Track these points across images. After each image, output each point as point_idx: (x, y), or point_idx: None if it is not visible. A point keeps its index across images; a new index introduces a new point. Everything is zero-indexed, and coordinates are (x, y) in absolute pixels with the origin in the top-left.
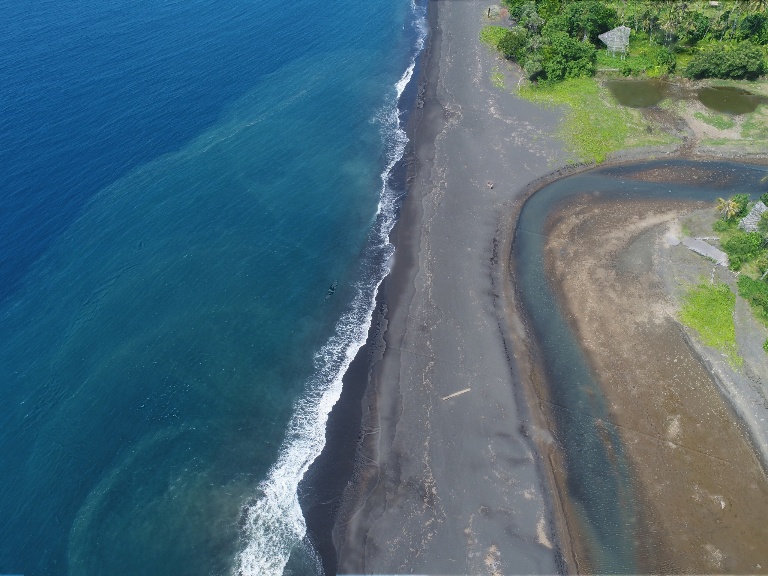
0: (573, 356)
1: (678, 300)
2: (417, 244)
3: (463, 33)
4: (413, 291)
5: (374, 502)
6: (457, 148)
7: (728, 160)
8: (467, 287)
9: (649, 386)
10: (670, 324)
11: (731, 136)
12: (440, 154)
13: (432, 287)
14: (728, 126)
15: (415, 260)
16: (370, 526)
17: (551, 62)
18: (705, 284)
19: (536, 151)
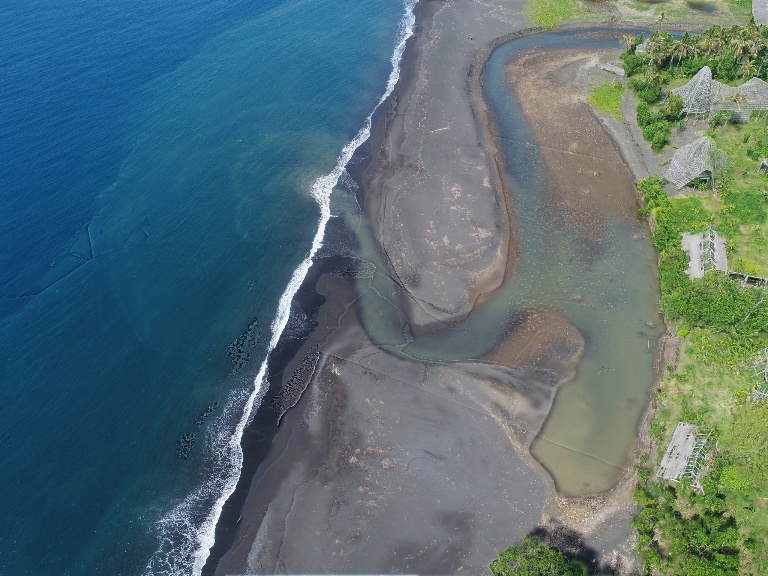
0: (516, 118)
1: (588, 92)
2: (418, 67)
3: None
4: (414, 88)
5: (387, 173)
6: (449, 19)
7: (641, 28)
8: (450, 85)
9: (562, 130)
10: (581, 104)
11: (646, 15)
12: (436, 22)
13: (427, 86)
14: (646, 9)
15: (416, 75)
16: (385, 181)
17: None
18: (607, 84)
19: (505, 21)
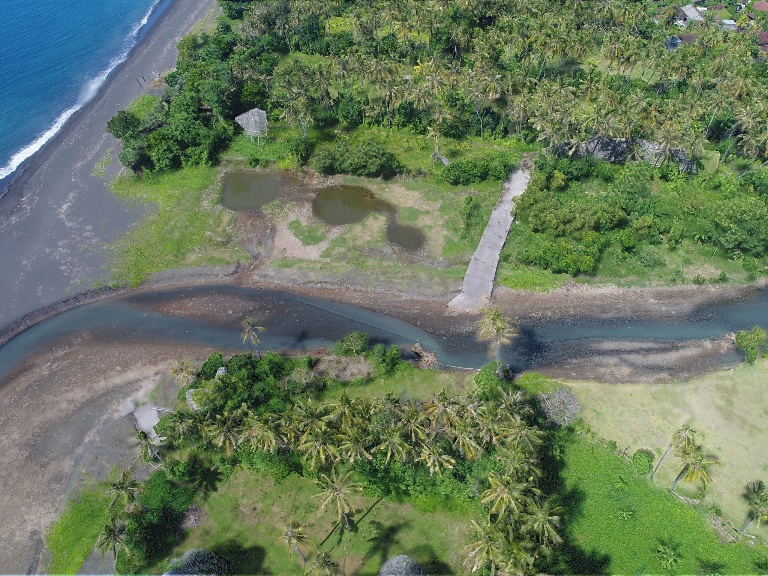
0: None
1: (65, 504)
2: None
3: (118, 101)
4: None
5: None
6: None
7: (284, 289)
8: None
9: None
10: (31, 542)
11: (309, 255)
12: None
13: None
14: (316, 241)
15: None
16: None
17: (155, 150)
18: (110, 481)
19: (68, 268)
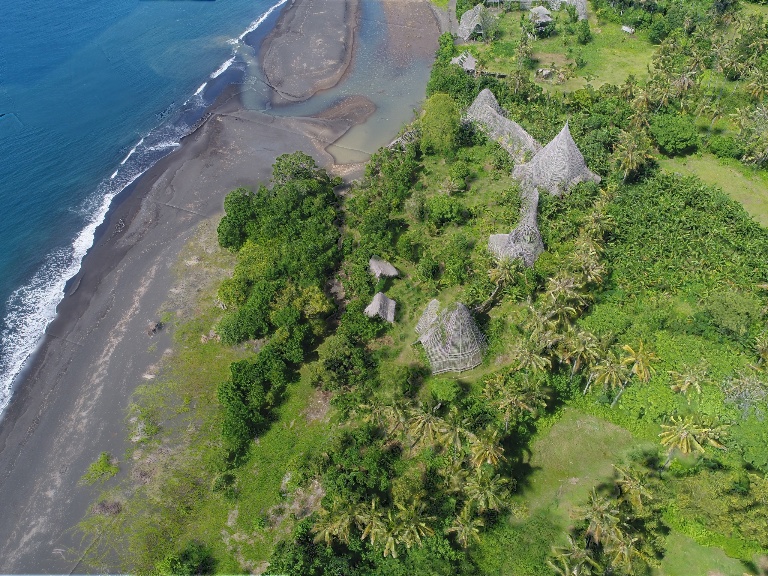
0: None
1: None
2: None
3: None
4: None
5: (277, 35)
6: None
7: None
8: None
9: (405, 15)
10: (424, 2)
11: None
12: None
13: None
14: None
15: None
16: (274, 39)
17: None
18: None
19: None
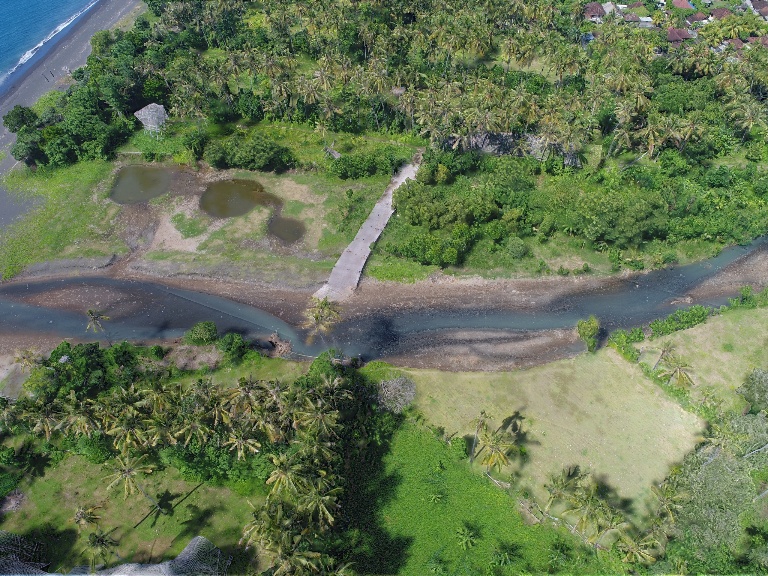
0: None
1: None
2: None
3: (27, 97)
4: None
5: None
6: None
7: (156, 280)
8: None
9: None
10: None
11: (186, 247)
12: None
13: None
14: (196, 234)
15: None
16: None
17: (48, 144)
18: None
19: None
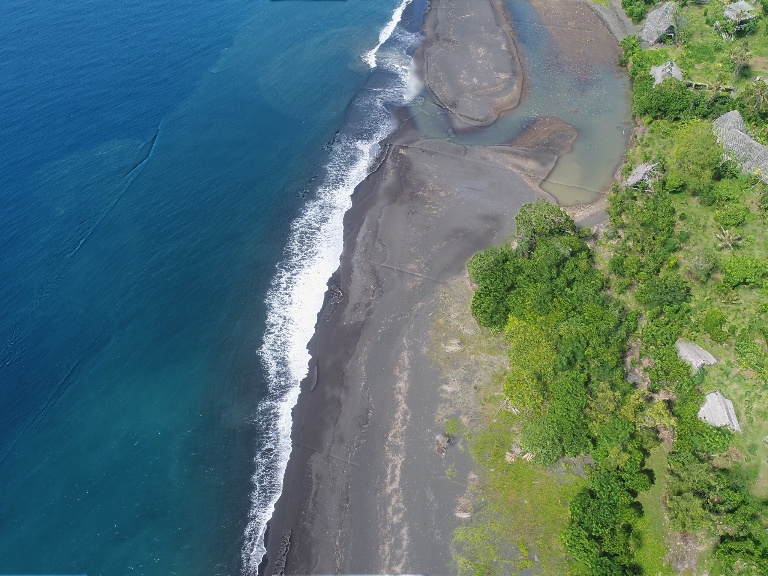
0: (526, 9)
1: None
2: None
3: None
4: None
5: (427, 45)
6: None
7: None
8: None
9: (562, 15)
10: None
11: None
12: None
13: None
14: None
15: None
16: (426, 49)
17: None
18: None
19: None
